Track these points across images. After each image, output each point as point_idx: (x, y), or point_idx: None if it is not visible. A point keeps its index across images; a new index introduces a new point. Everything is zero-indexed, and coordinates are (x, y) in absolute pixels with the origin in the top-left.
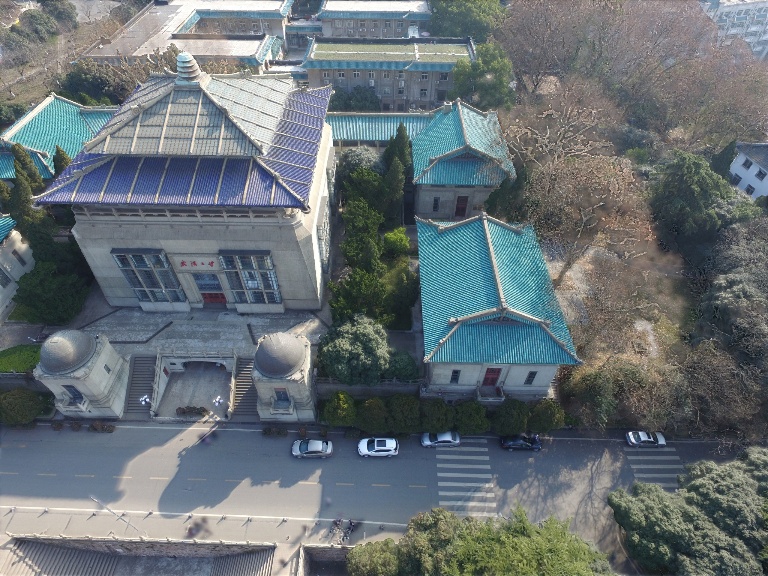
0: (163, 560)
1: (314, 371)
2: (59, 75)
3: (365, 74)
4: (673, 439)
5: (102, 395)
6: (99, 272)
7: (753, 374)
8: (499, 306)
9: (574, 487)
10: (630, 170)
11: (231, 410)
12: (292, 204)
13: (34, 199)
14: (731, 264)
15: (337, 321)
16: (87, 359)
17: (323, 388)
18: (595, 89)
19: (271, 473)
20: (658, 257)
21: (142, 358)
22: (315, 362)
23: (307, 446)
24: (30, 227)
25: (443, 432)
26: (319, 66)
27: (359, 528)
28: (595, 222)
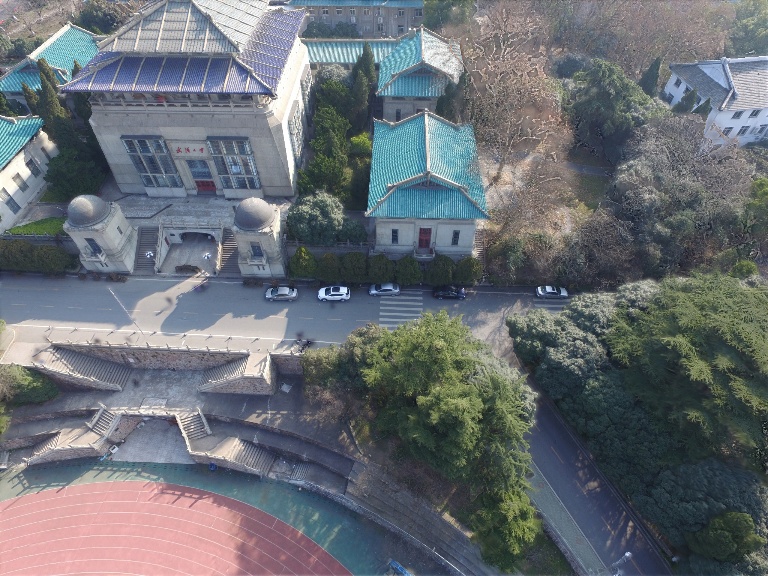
0: (165, 372)
1: (284, 236)
2: (73, 13)
3: (347, 11)
4: (575, 294)
5: (116, 250)
6: (112, 159)
7: (628, 227)
8: (425, 171)
9: (487, 323)
10: (540, 65)
11: (219, 268)
12: (262, 92)
13: (59, 87)
14: (636, 155)
15: (302, 194)
16: (104, 217)
17: (292, 251)
18: (548, 18)
19: (248, 310)
20: (588, 161)
21: (148, 228)
22: (285, 229)
23: (277, 291)
24: (56, 119)
25: (386, 282)
26: (305, 3)
27: (314, 345)
28: (521, 119)
